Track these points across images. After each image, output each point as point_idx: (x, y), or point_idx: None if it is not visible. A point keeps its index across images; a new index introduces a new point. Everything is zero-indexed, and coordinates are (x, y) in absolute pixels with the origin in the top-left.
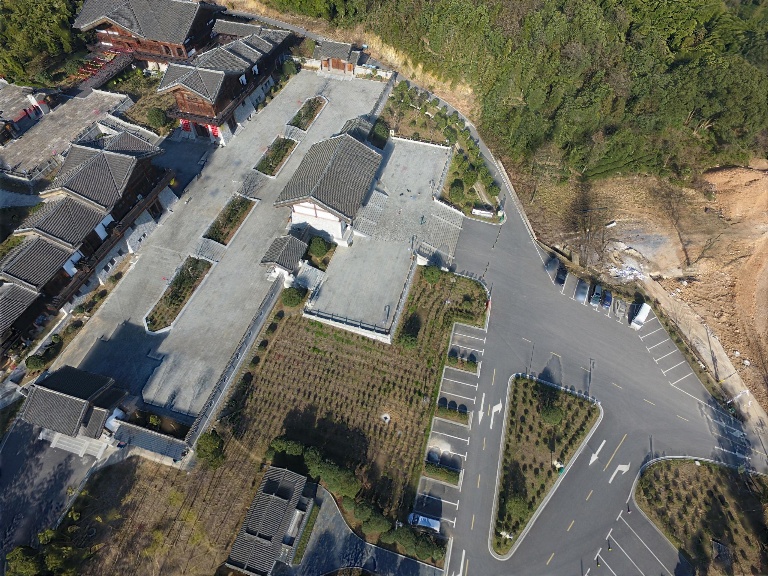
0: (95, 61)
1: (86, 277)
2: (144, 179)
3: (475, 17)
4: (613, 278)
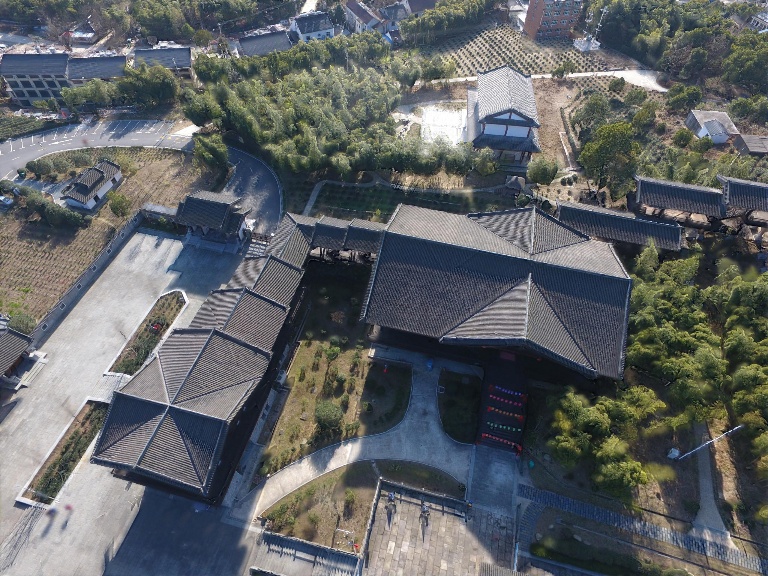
0: None
1: None
2: None
3: None
4: None
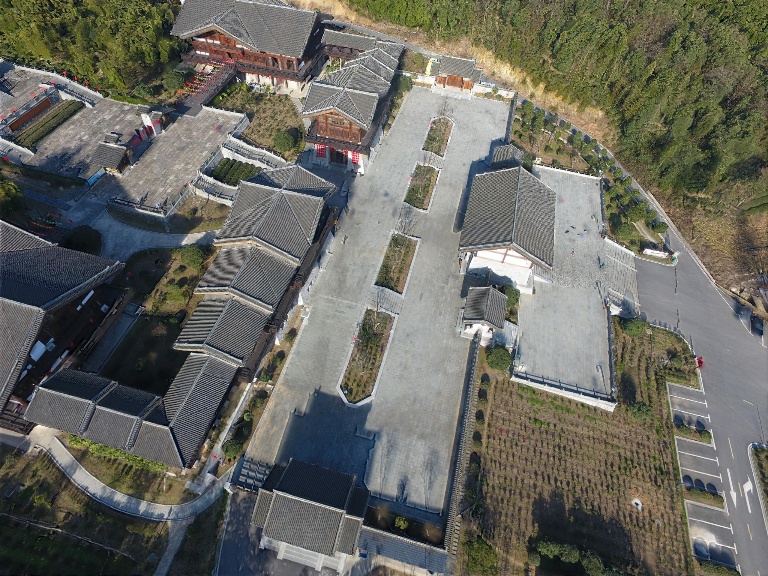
0: (192, 72)
1: (271, 339)
2: None
3: (614, 36)
4: None
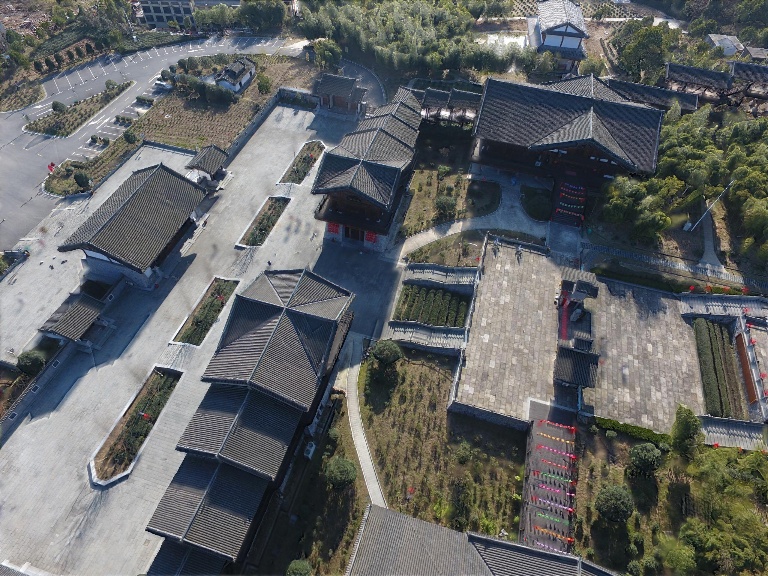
0: None
1: None
2: None
3: None
4: None
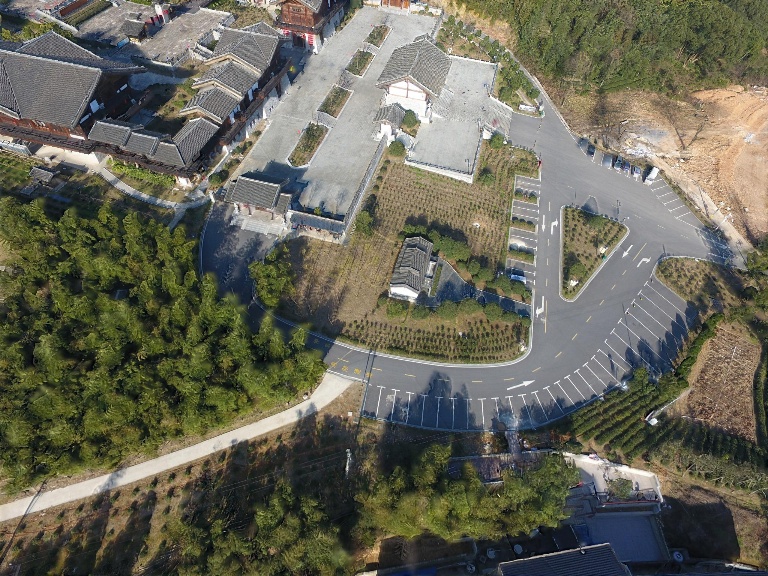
0: None
1: (242, 126)
2: (275, 61)
3: None
4: (629, 155)
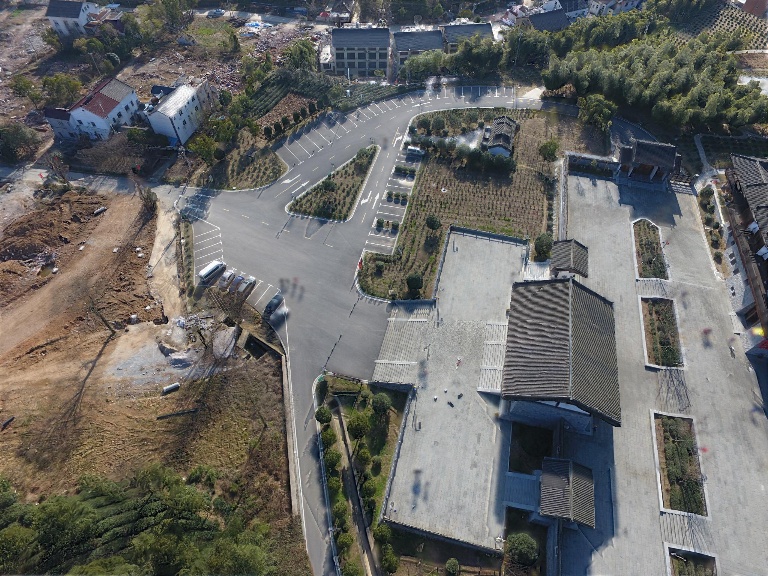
0: None
1: None
2: None
3: None
4: None
